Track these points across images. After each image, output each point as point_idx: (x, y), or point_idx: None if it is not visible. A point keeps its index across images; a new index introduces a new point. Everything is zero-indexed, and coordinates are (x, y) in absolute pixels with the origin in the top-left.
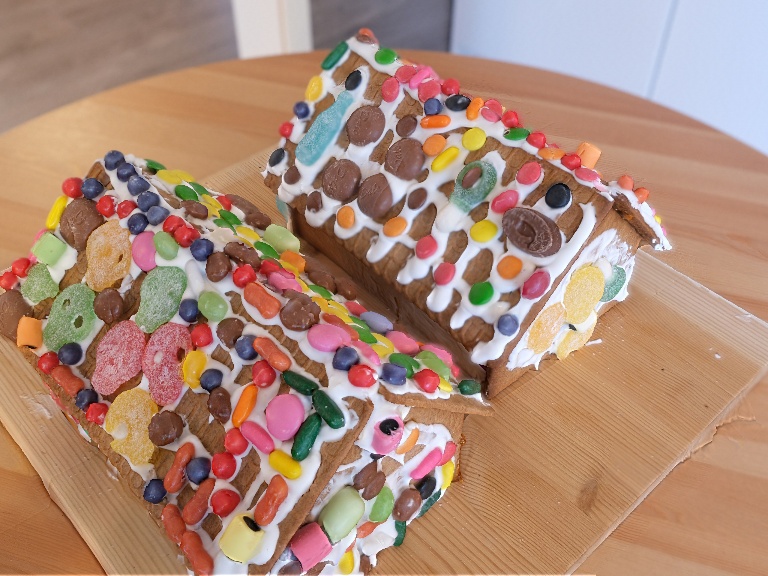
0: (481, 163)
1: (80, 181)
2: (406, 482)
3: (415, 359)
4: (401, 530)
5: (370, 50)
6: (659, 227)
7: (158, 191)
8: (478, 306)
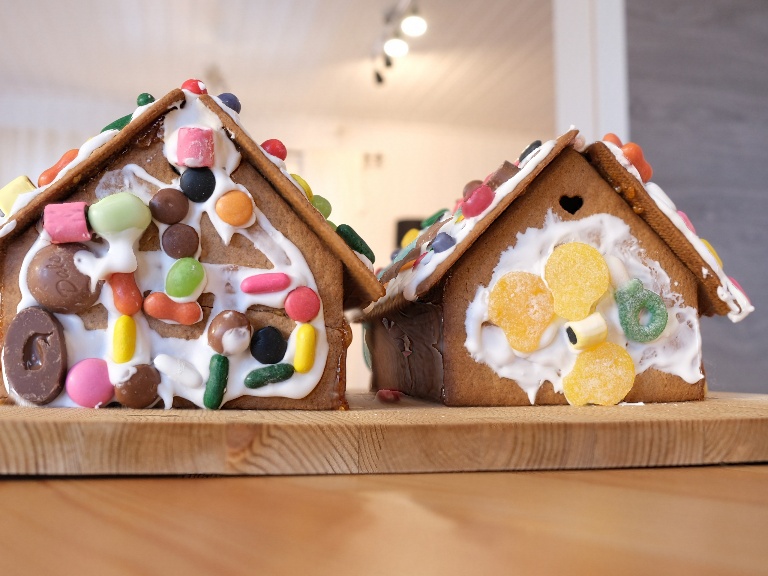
0: None
1: None
2: (240, 308)
3: None
4: (214, 369)
5: None
6: (699, 241)
7: None
8: None
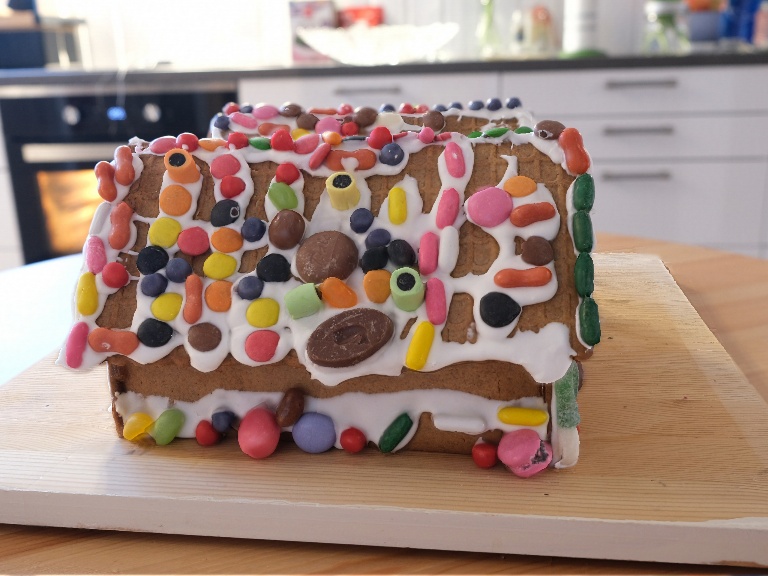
0: None
1: None
2: None
3: None
4: None
5: None
6: None
7: (476, 122)
8: None
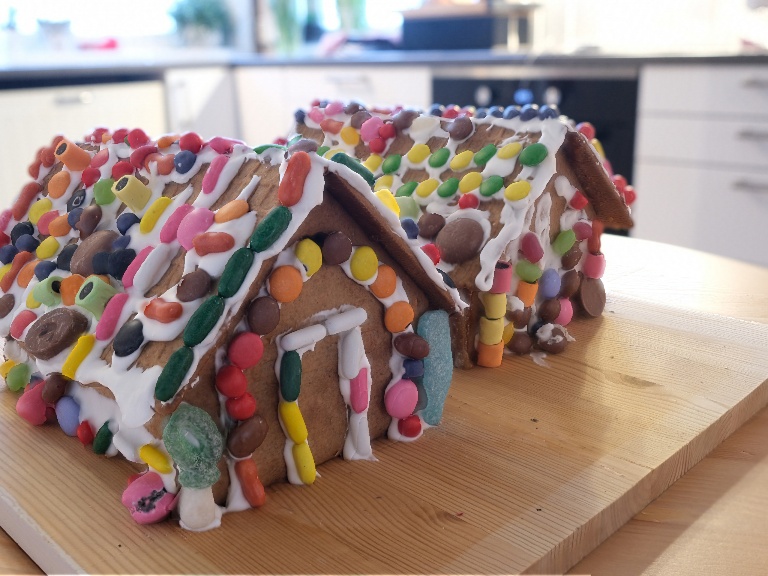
0: None
1: None
2: None
3: None
4: None
5: None
6: None
7: (503, 133)
8: None
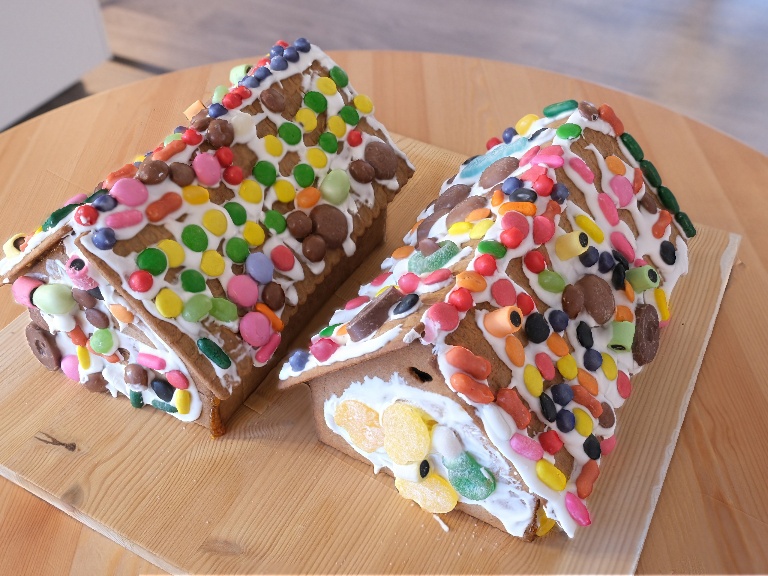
0: (446, 244)
1: (286, 47)
2: None
3: (205, 291)
4: None
5: (574, 120)
6: (526, 472)
7: (293, 81)
8: (319, 335)
